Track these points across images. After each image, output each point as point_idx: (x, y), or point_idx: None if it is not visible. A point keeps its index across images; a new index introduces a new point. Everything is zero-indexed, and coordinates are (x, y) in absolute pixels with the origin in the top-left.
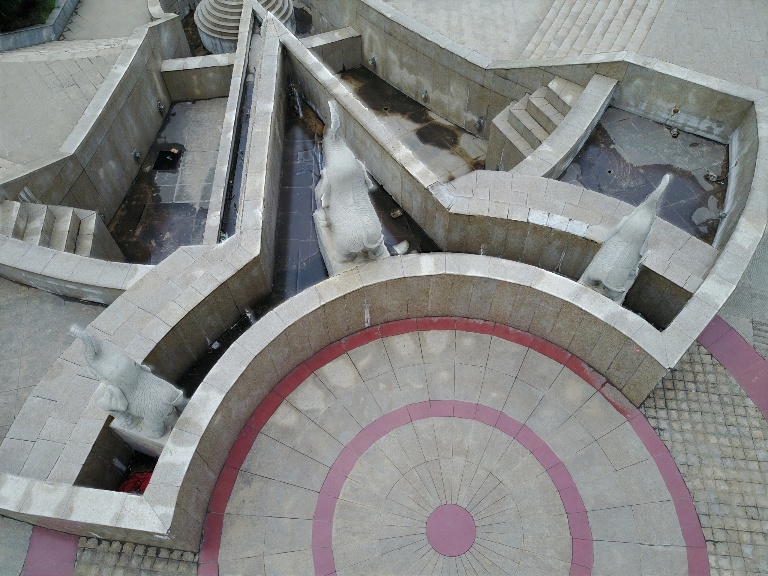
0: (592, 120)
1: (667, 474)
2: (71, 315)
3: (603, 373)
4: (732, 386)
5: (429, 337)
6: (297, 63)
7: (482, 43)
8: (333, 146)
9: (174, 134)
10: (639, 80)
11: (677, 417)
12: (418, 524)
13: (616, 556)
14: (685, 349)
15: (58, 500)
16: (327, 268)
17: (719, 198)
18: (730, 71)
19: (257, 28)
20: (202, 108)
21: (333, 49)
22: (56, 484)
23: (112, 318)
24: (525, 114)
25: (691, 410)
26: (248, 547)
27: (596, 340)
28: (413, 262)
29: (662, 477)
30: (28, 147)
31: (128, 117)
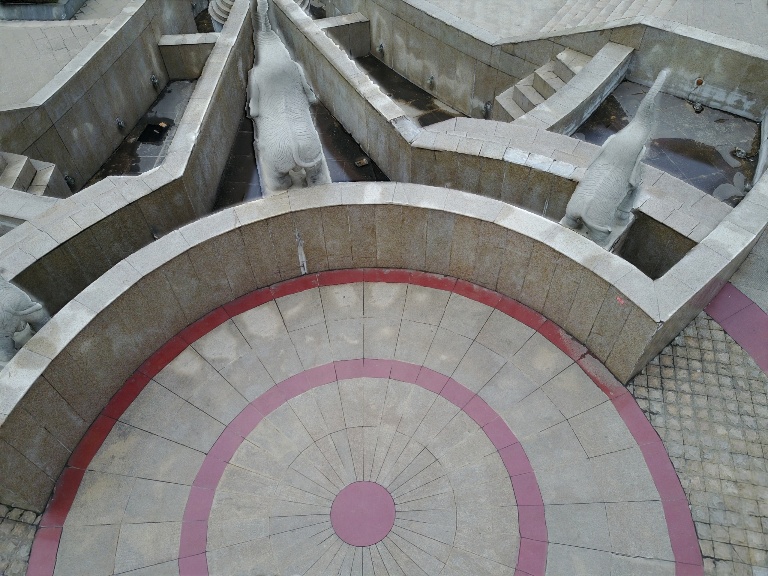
0: (600, 84)
1: (656, 467)
2: None
3: (584, 342)
4: (750, 368)
5: (375, 289)
6: (273, 6)
7: (494, 26)
8: (264, 40)
9: (166, 109)
10: (658, 46)
11: (675, 400)
12: (322, 502)
13: (577, 565)
14: (683, 301)
15: None
16: None
17: (747, 175)
18: (765, 43)
19: None
20: None
21: (339, 33)
22: None
23: (10, 242)
24: (531, 90)
25: (694, 393)
26: (104, 512)
27: (574, 294)
28: (355, 190)
29: (649, 471)
30: (2, 101)
31: (114, 82)
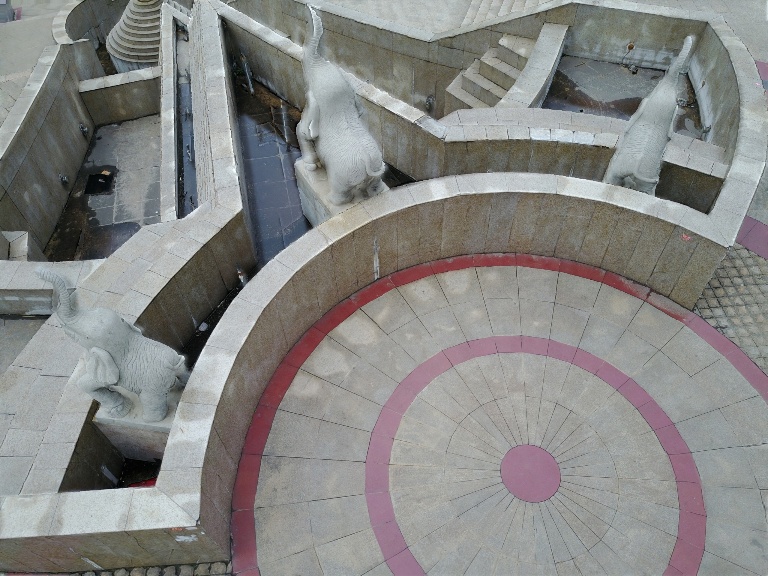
0: (555, 61)
1: (745, 370)
2: (15, 334)
3: (645, 283)
4: None
5: (448, 278)
6: (241, 33)
7: (418, 24)
8: (316, 62)
9: (103, 157)
10: (590, 21)
11: (735, 313)
12: (491, 474)
13: (722, 464)
14: (738, 226)
15: (40, 514)
16: (318, 224)
17: (694, 120)
18: (672, 5)
19: (180, 35)
20: (130, 128)
21: None
22: (34, 495)
23: None
24: (479, 77)
25: (746, 303)
26: (292, 541)
27: (635, 243)
28: (422, 189)
29: (741, 374)
30: None
31: (49, 137)
